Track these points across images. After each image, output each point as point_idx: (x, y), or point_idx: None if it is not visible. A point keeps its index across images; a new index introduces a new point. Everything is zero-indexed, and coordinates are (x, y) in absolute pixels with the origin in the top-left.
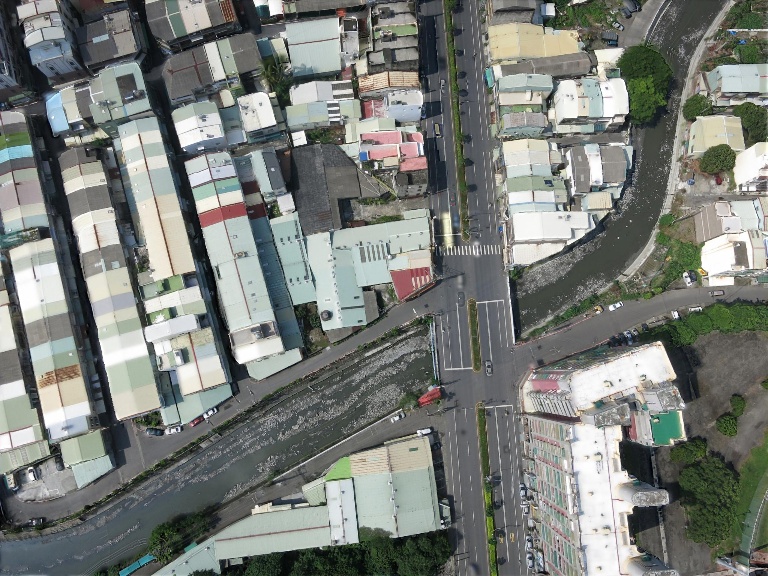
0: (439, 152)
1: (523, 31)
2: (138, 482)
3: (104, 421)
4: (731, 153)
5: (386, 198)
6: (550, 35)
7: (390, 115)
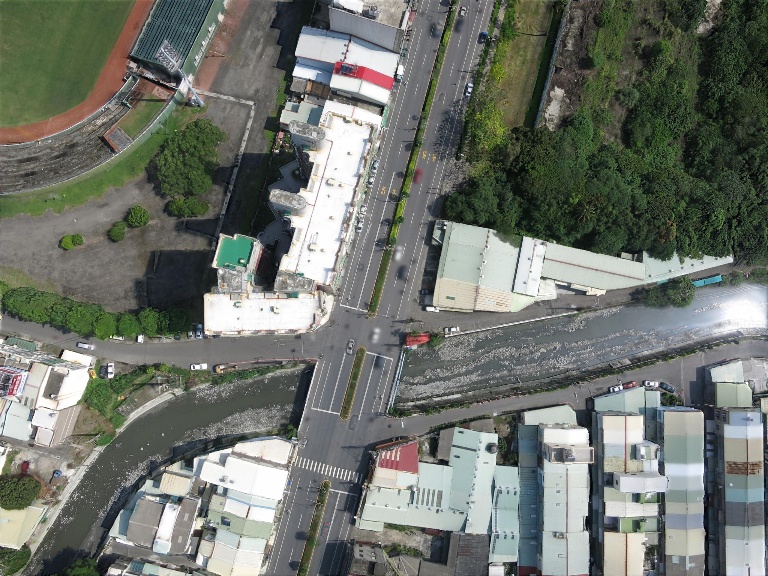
0: None
1: None
2: (689, 348)
3: (709, 412)
4: (2, 497)
5: (394, 551)
6: None
7: None
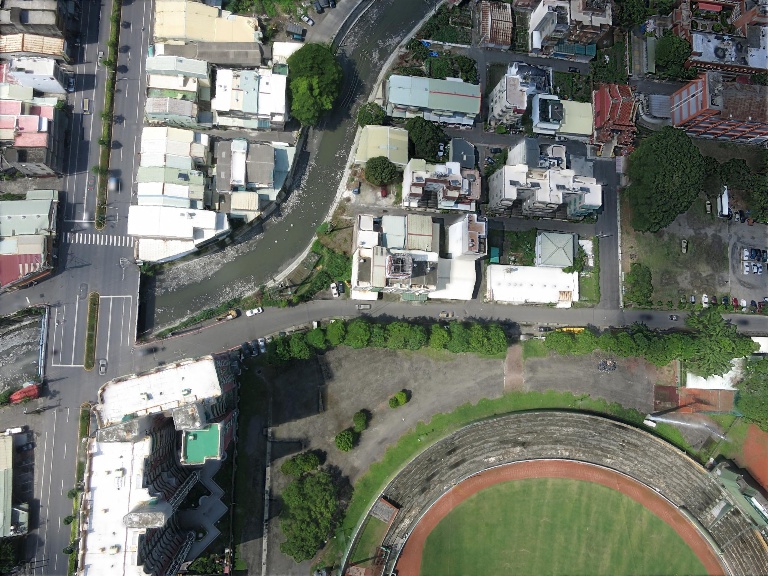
0: (84, 130)
1: (192, 11)
2: None
3: None
4: (389, 166)
5: (12, 174)
6: (224, 19)
7: (23, 83)
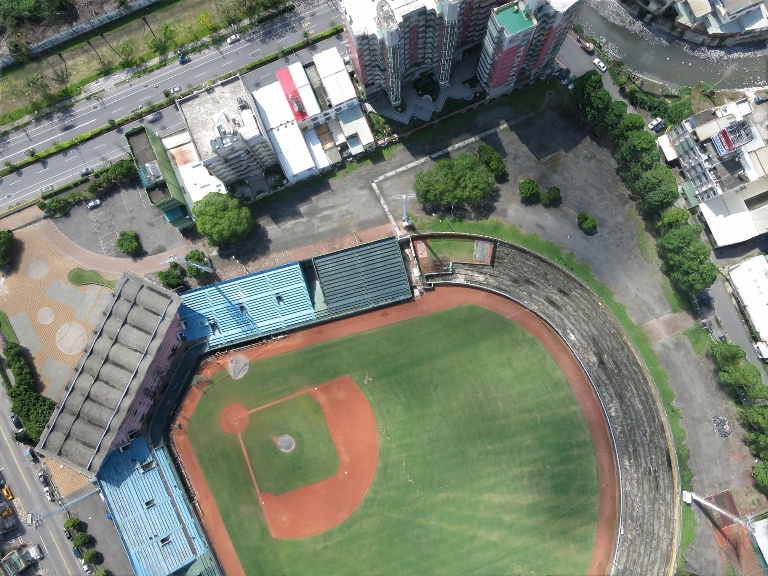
0: None
1: None
2: None
3: None
4: None
5: None
6: None
7: None
